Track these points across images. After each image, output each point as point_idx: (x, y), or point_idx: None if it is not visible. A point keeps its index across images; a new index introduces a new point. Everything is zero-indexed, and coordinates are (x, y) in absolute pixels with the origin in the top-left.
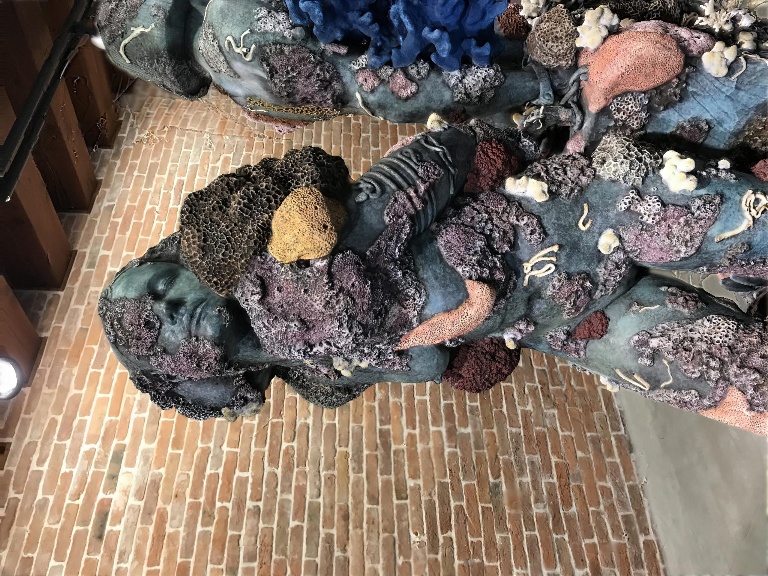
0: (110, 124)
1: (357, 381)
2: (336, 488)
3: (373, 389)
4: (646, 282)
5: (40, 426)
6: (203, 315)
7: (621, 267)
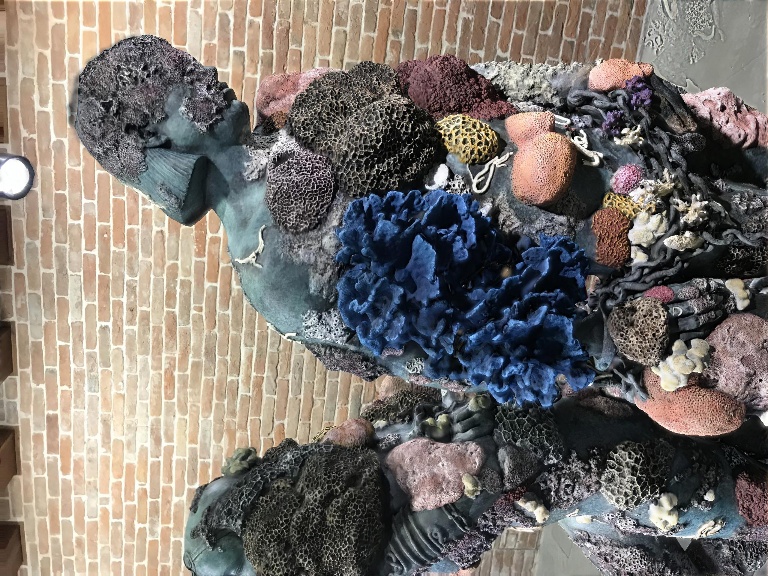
0: None
1: None
2: None
3: (384, 48)
4: None
5: (30, 62)
6: None
7: None
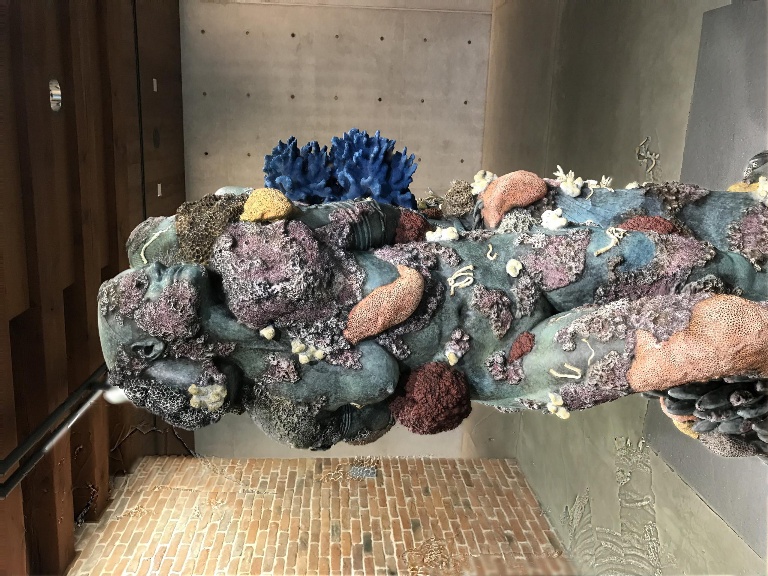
0: (101, 500)
1: (316, 389)
2: None
3: None
4: None
5: None
6: (185, 269)
7: (531, 290)
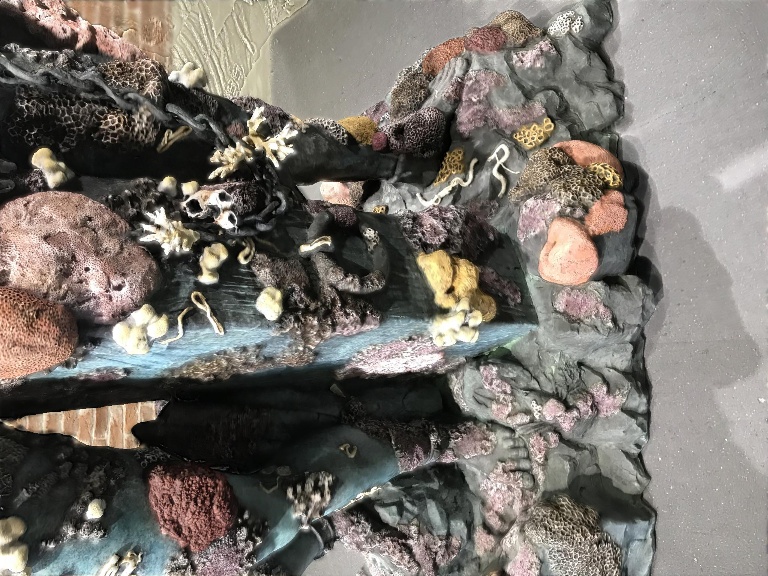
0: None
1: None
2: None
3: None
4: None
5: None
6: None
7: None
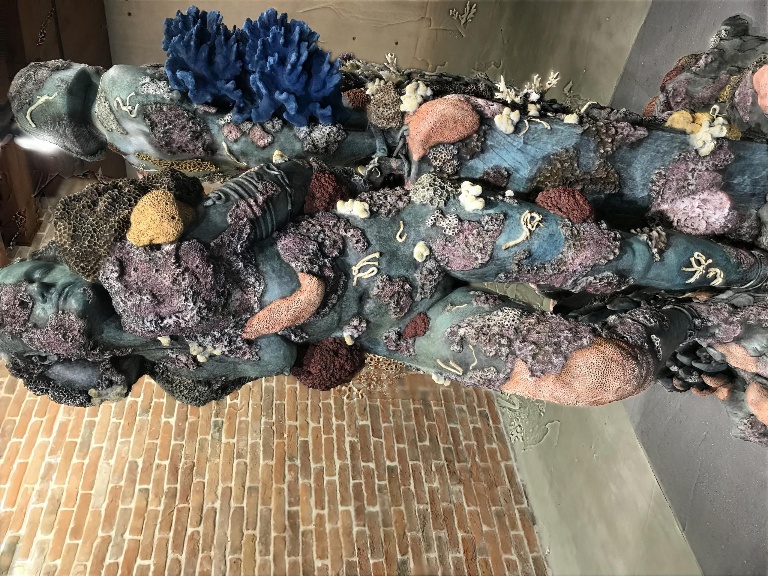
0: (30, 223)
1: (215, 373)
2: (242, 572)
3: (283, 471)
4: (460, 290)
5: None
6: (70, 293)
7: (435, 273)
